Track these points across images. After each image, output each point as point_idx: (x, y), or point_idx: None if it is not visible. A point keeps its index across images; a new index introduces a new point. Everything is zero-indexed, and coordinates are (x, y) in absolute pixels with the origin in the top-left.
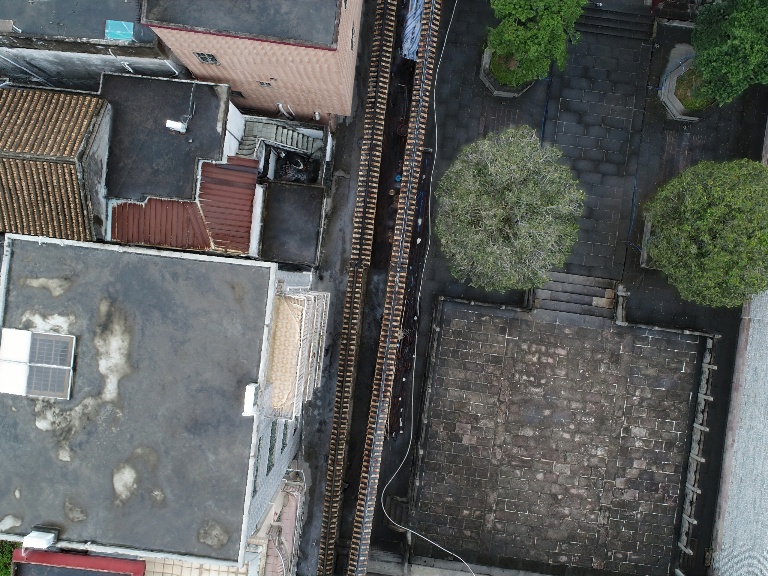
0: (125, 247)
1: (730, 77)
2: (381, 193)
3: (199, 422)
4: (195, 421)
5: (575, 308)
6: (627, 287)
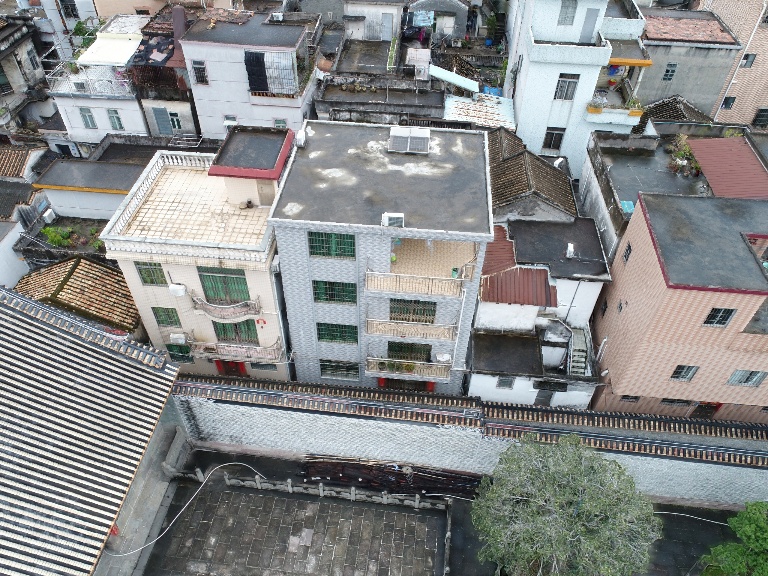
0: None
1: None
2: None
3: (374, 202)
4: (374, 201)
5: None
6: None
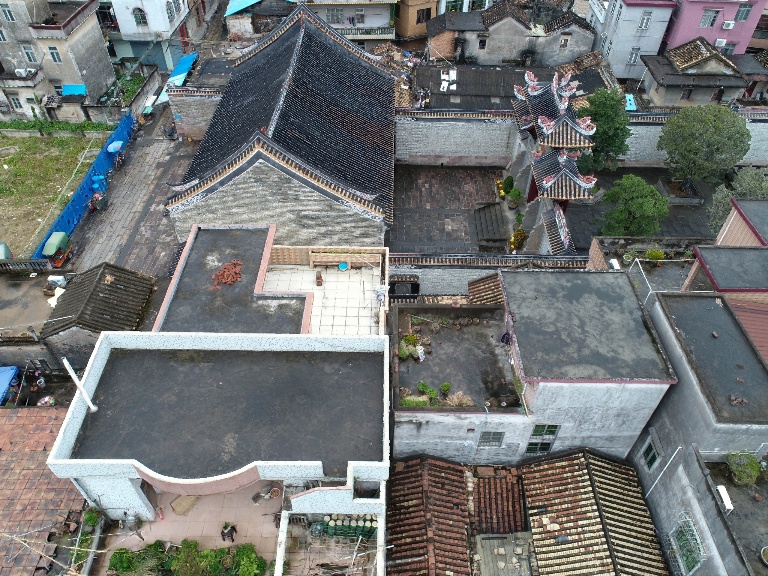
0: None
1: (631, 135)
2: None
3: None
4: None
5: None
6: None
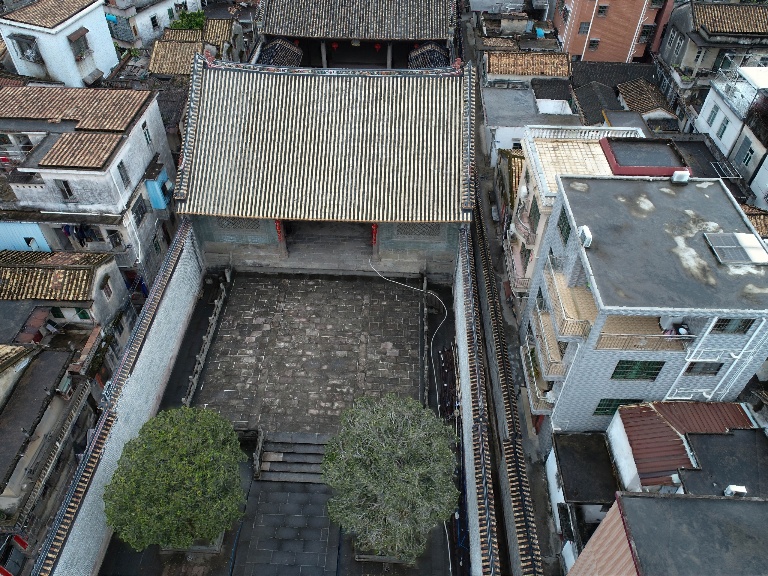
0: (719, 311)
1: None
2: (502, 545)
3: (613, 230)
4: (616, 230)
5: (300, 449)
6: (246, 478)
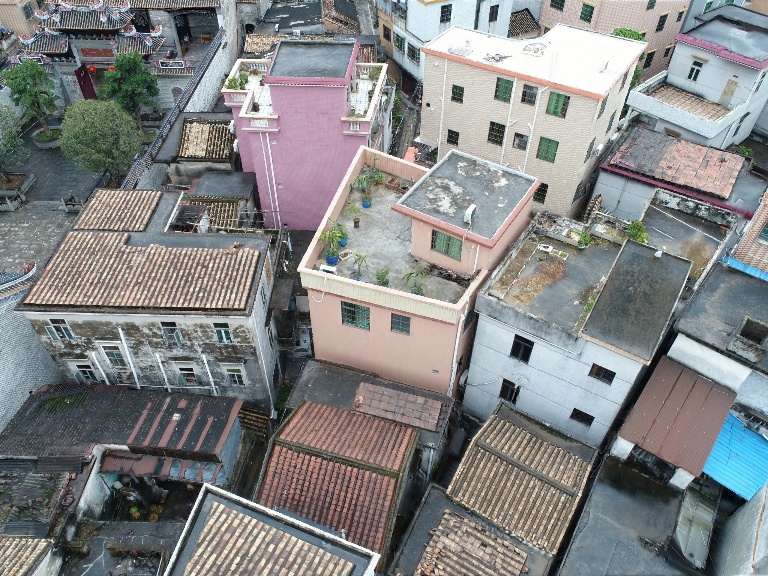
0: None
1: None
2: None
3: None
4: None
5: None
6: None
